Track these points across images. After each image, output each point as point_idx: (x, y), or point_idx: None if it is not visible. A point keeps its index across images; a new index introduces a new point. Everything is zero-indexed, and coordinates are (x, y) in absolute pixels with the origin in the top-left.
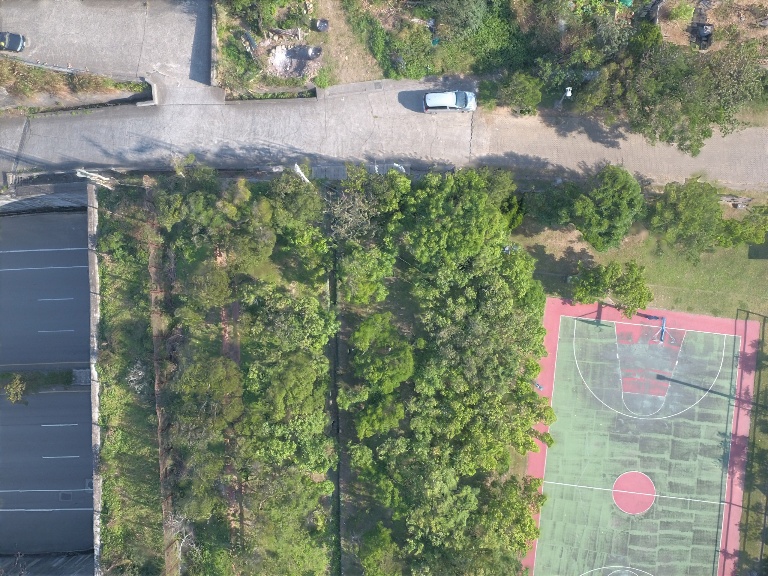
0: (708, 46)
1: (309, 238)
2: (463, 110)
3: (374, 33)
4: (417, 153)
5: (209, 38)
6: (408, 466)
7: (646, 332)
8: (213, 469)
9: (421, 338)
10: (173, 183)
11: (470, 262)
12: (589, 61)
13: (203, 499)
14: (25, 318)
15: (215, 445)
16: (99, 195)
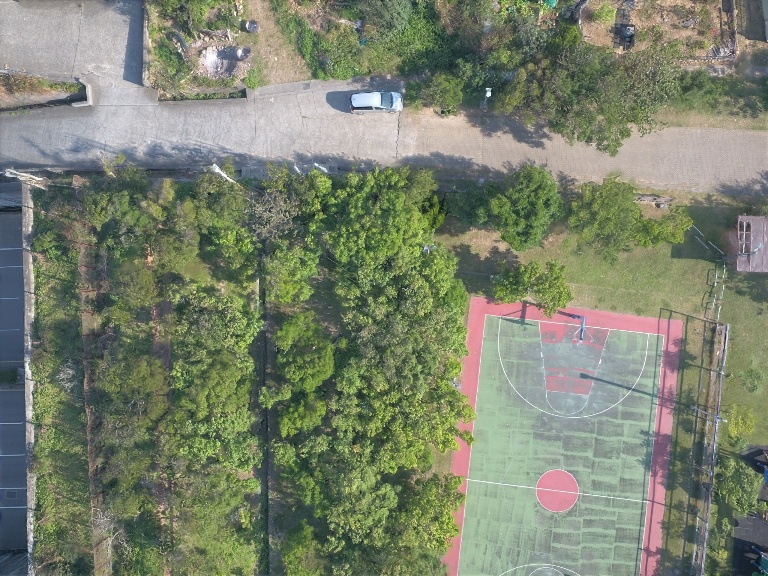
0: (631, 47)
1: (233, 237)
2: (389, 110)
3: (302, 34)
4: (344, 153)
5: (142, 39)
6: (331, 464)
7: (570, 331)
8: (139, 467)
9: (343, 337)
10: (106, 183)
11: (388, 261)
12: (508, 62)
13: (129, 496)
14: None
15: (145, 443)
16: (34, 195)
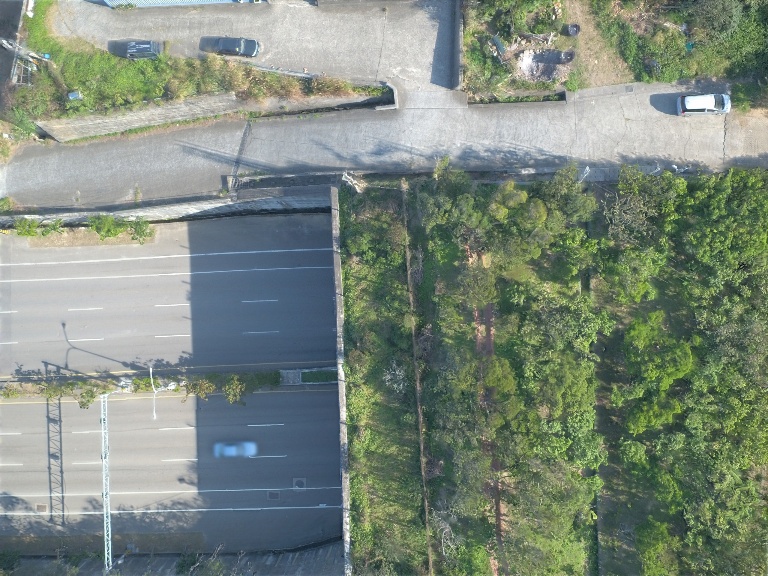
0: None
1: (579, 239)
2: (718, 112)
3: (626, 37)
4: (671, 155)
5: (451, 43)
6: (681, 461)
7: None
8: (484, 466)
9: (695, 336)
10: (419, 186)
11: (752, 261)
12: None
13: (475, 495)
14: (229, 320)
15: None
16: (340, 198)
